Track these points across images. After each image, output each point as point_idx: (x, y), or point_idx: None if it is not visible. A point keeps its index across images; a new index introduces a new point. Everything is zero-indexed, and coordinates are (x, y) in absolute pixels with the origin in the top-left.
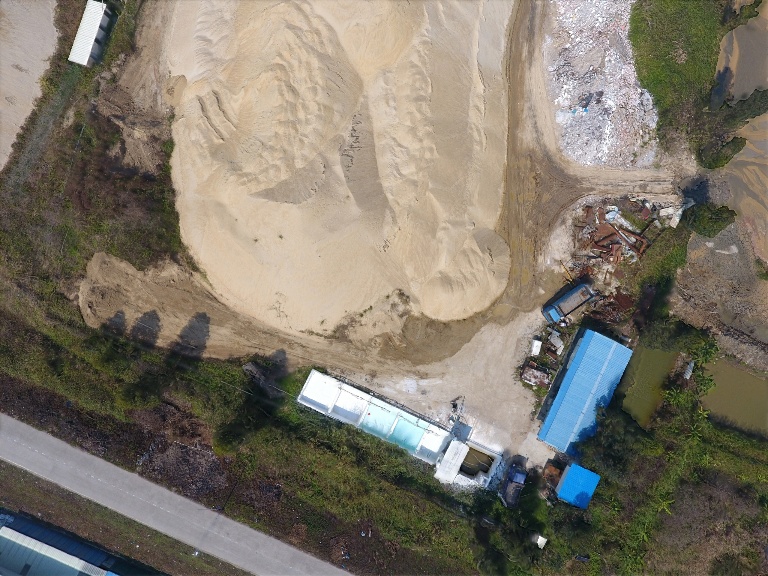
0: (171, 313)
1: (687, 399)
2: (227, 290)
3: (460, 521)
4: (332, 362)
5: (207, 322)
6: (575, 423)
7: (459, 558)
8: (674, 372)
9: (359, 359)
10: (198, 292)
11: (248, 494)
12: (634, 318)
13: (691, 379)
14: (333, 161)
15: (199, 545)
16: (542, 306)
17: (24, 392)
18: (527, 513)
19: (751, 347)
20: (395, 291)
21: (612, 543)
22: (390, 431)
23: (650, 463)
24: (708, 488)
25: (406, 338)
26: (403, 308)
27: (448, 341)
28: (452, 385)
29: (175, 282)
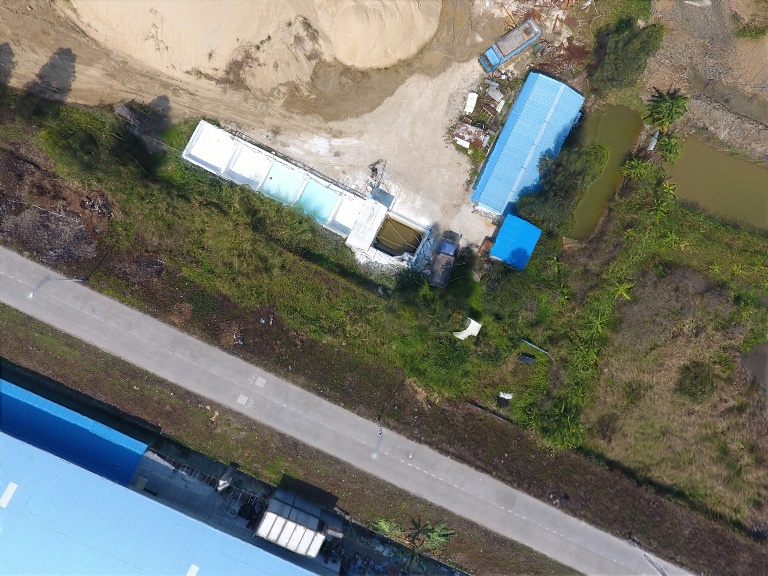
0: (28, 47)
1: (651, 174)
2: (94, 15)
3: (378, 302)
4: (226, 114)
5: (73, 60)
6: (514, 180)
7: (379, 355)
8: (636, 148)
9: (259, 112)
10: (61, 23)
11: (121, 267)
12: (588, 70)
13: (656, 152)
14: None
15: (58, 323)
16: (479, 56)
17: None
18: (460, 300)
19: (726, 114)
20: (298, 18)
21: (560, 335)
22: (295, 197)
23: (606, 243)
24: (674, 276)
25: (316, 88)
26: (311, 47)
27: (367, 94)
28: (371, 146)
29: (33, 10)
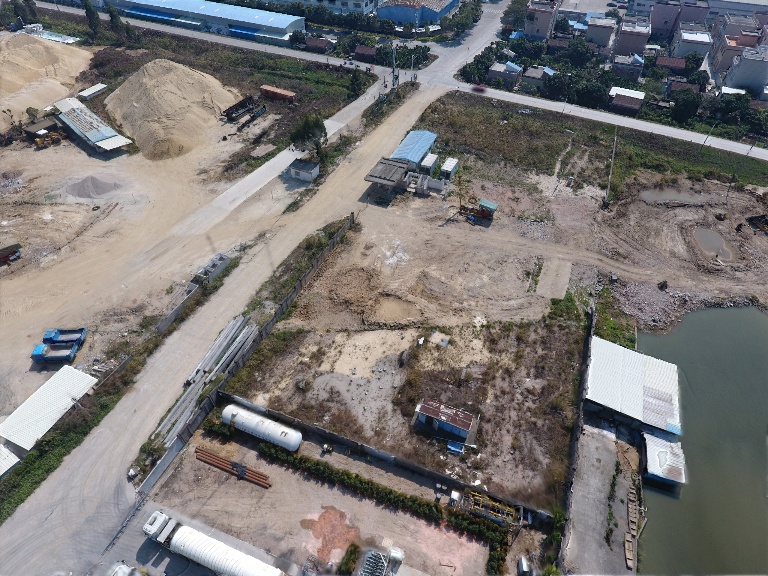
0: None
1: None
2: None
3: None
4: None
5: None
6: None
7: None
8: None
9: None
10: None
11: None
12: None
13: None
14: (4, 45)
15: None
16: None
17: (179, 41)
18: None
19: None
20: None
21: None
22: None
23: None
24: None
25: None
26: None
27: None
28: None
29: None
